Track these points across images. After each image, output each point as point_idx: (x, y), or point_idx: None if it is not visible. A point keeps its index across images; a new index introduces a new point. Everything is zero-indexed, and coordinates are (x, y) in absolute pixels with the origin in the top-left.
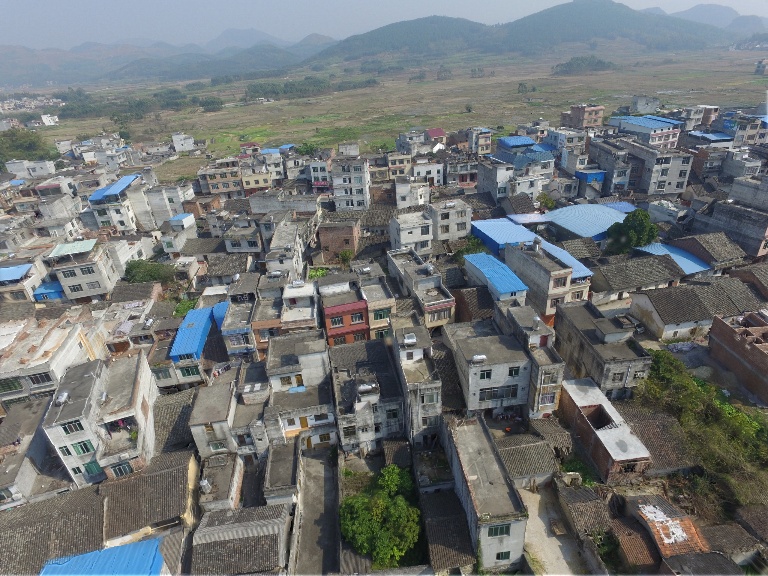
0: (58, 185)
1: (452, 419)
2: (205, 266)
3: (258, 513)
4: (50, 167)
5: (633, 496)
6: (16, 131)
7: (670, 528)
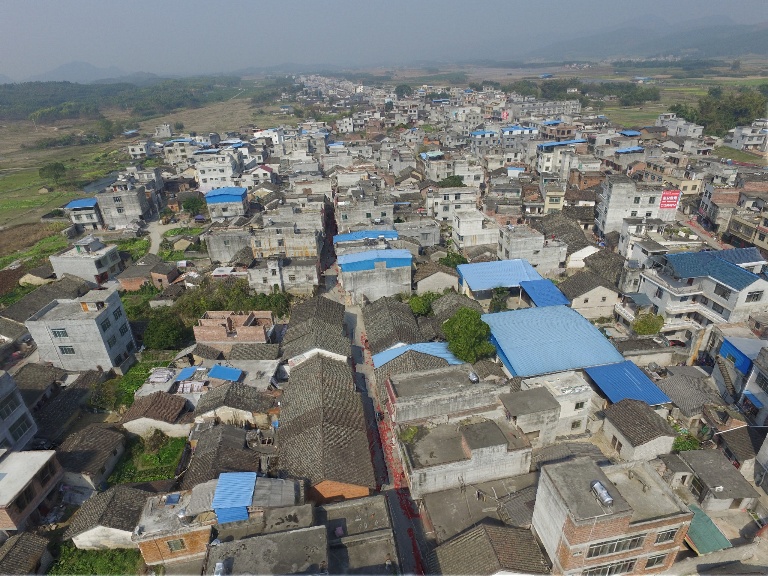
0: (596, 137)
1: (251, 226)
2: (479, 200)
3: (261, 221)
4: (693, 131)
5: (205, 277)
6: (748, 96)
7: (185, 275)
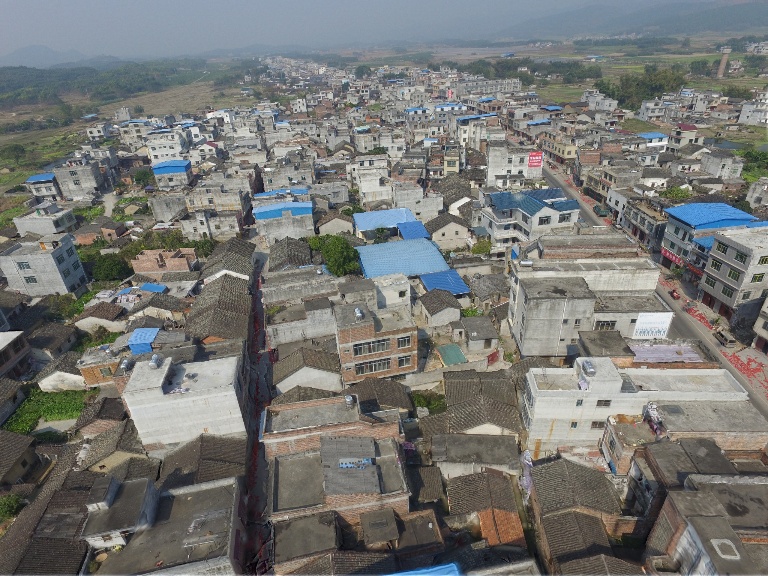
0: (514, 112)
1: None
2: None
3: None
4: (609, 105)
5: (148, 231)
6: (663, 73)
7: (131, 230)
